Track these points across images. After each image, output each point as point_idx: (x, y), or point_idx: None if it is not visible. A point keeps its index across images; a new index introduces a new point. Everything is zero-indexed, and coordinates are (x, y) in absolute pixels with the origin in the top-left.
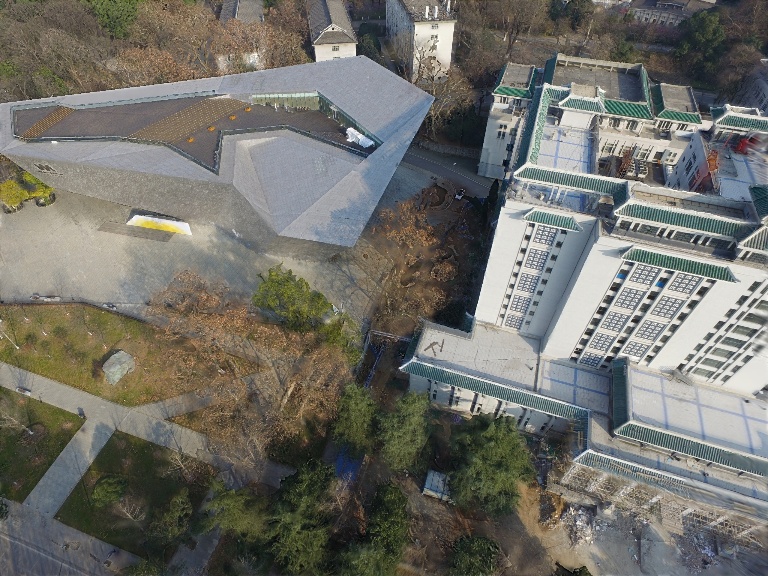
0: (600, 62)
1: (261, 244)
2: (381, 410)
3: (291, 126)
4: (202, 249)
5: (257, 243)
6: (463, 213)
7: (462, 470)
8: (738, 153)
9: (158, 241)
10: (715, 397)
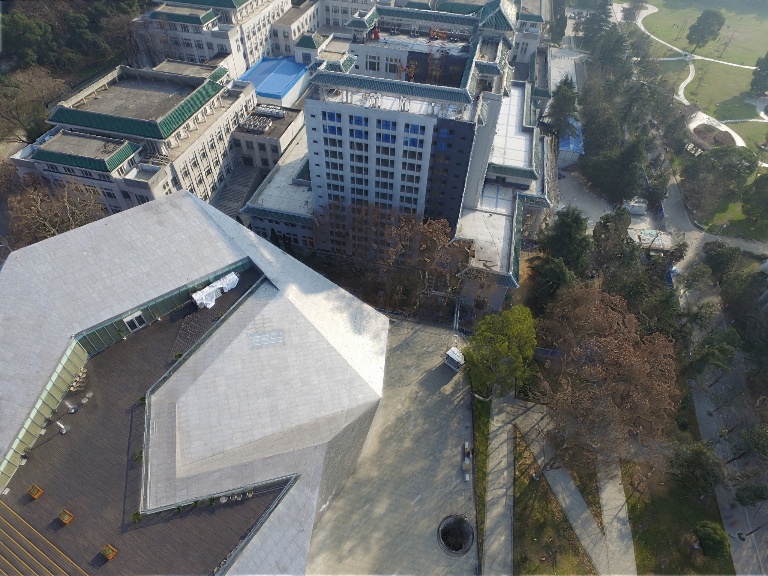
0: (94, 86)
1: None
2: None
3: (152, 385)
4: (348, 569)
5: (355, 458)
6: None
7: (579, 257)
8: (377, 40)
9: None
10: (498, 142)
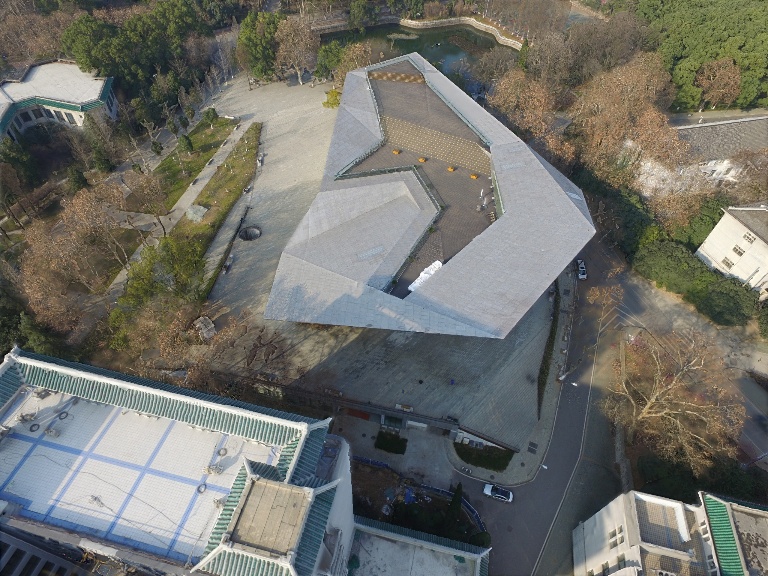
0: None
1: None
2: None
3: None
4: None
5: None
6: (447, 497)
7: None
8: None
9: None
10: None
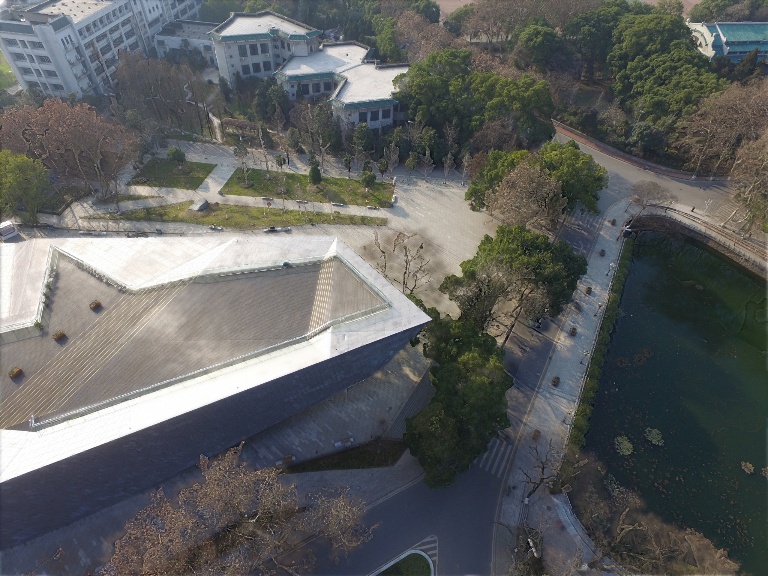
0: None
1: None
2: (2, 214)
3: None
4: None
5: None
6: None
7: None
8: None
9: None
10: None
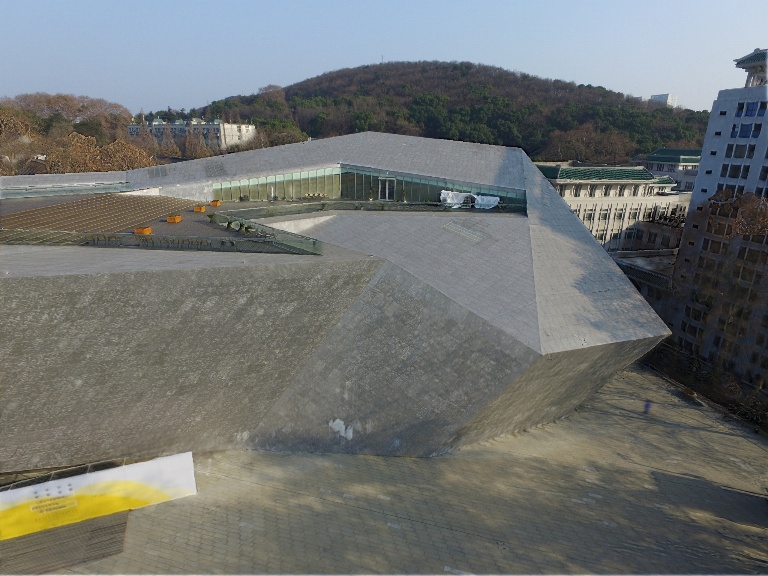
0: (541, 163)
1: (453, 418)
2: None
3: None
4: (268, 516)
5: (436, 422)
6: None
7: None
8: None
9: (75, 567)
10: None
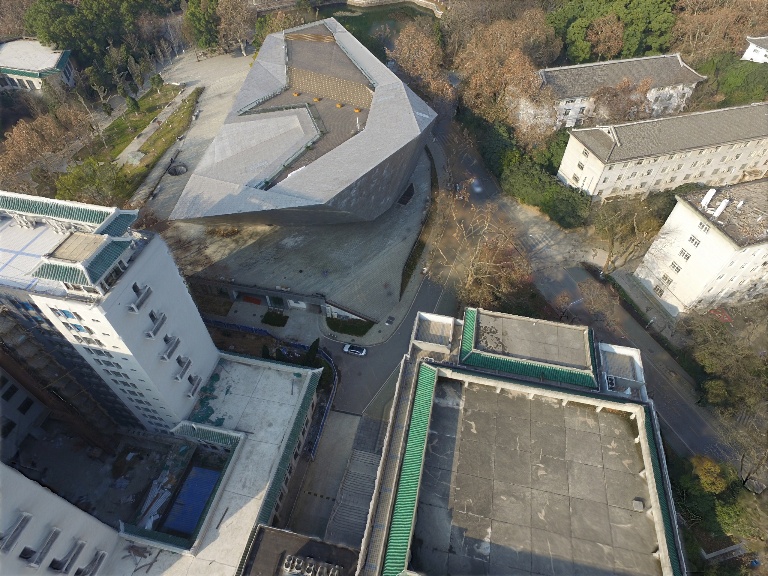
0: (656, 512)
1: None
2: None
3: None
4: None
5: None
6: None
7: None
8: None
9: None
10: None
